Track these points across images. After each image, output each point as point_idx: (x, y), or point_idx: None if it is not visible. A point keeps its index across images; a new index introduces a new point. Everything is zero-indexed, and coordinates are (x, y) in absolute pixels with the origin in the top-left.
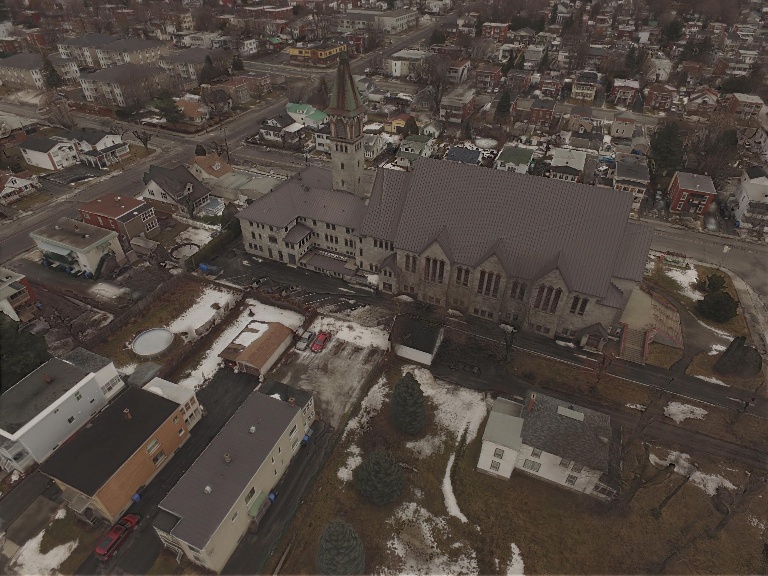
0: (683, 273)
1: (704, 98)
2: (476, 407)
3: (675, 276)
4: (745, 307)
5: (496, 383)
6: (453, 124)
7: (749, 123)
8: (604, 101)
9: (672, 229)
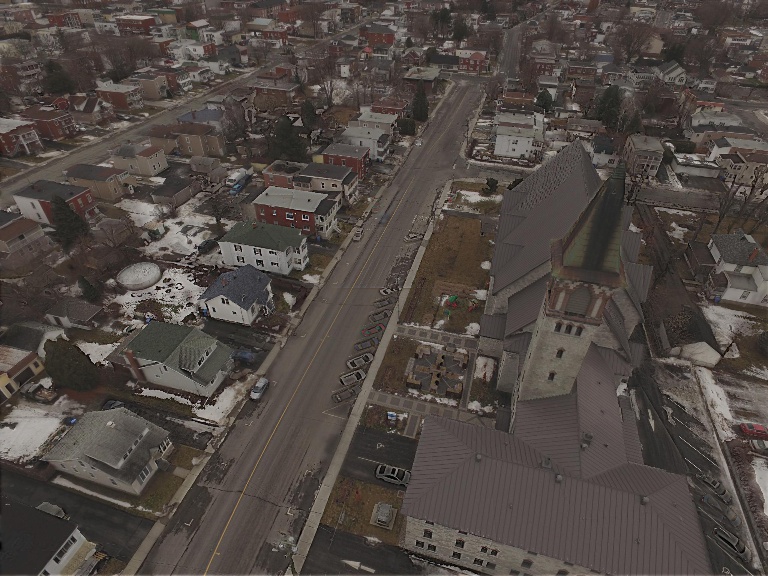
0: (468, 196)
1: (102, 103)
2: (718, 311)
3: (475, 200)
4: (498, 185)
5: (683, 299)
6: (4, 313)
7: (156, 108)
8: (7, 159)
9: (392, 187)
